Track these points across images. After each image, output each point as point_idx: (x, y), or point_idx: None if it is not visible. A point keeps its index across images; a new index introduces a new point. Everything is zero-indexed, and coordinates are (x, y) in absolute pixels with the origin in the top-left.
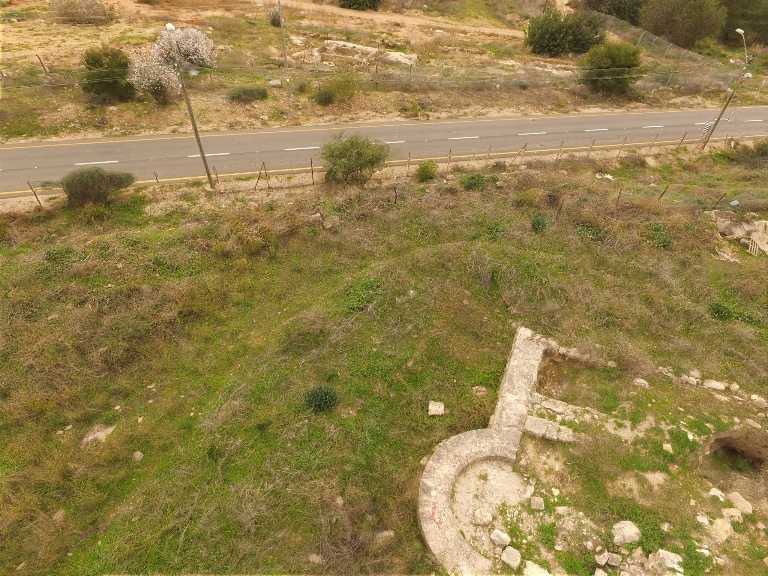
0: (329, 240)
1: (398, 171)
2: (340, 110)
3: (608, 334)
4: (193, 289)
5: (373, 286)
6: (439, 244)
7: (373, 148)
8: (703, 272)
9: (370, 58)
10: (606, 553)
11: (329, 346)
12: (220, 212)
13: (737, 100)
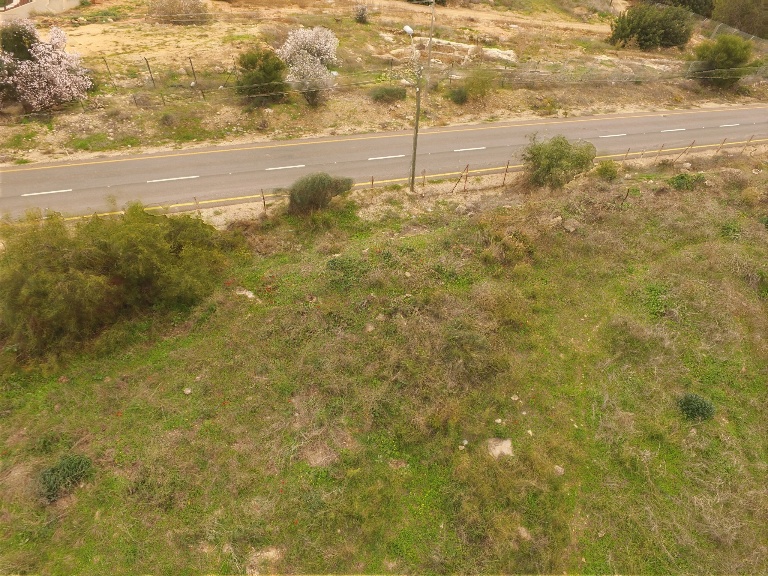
0: (587, 244)
1: None
2: (476, 109)
3: None
4: (501, 297)
5: (660, 290)
6: (686, 246)
7: (580, 149)
8: None
9: (472, 55)
10: None
11: (665, 353)
12: (432, 216)
13: None
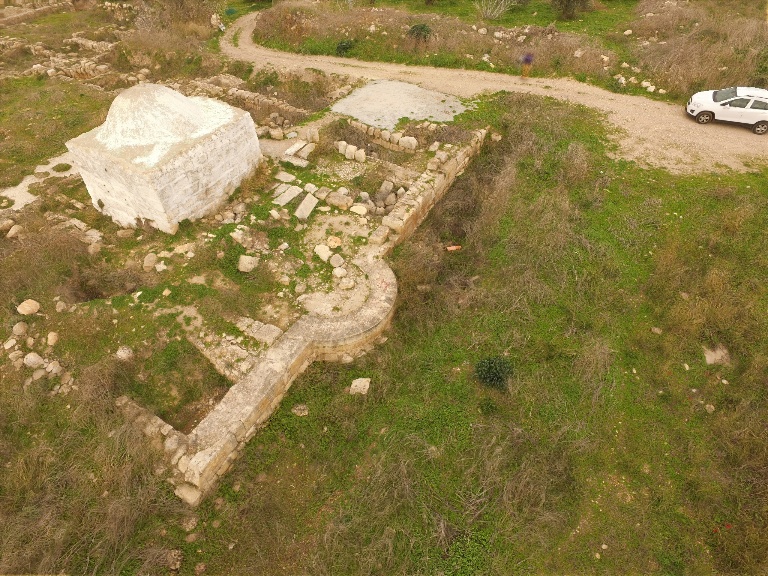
0: None
1: None
2: None
3: None
4: None
5: None
6: None
7: None
8: None
9: None
10: None
11: None
12: None
13: None
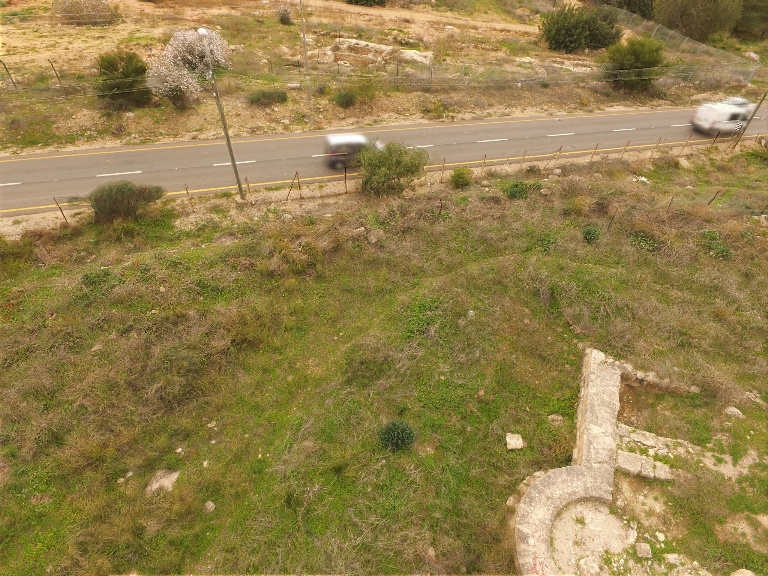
0: (378, 256)
1: (431, 177)
2: (362, 112)
3: (685, 356)
4: (244, 315)
5: (431, 307)
6: (491, 258)
7: (412, 156)
8: (767, 284)
9: (385, 57)
10: None
11: (396, 375)
12: (254, 225)
13: None
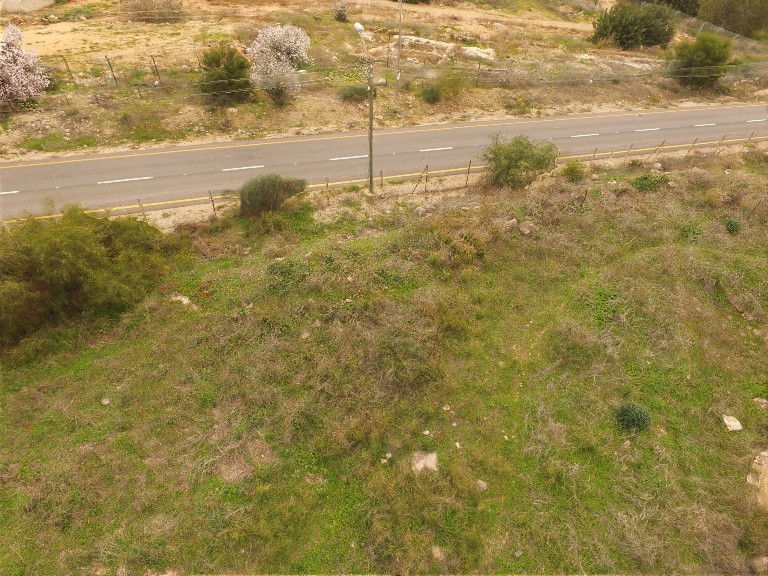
0: (540, 247)
1: None
2: (448, 108)
3: None
4: (442, 303)
5: (610, 295)
6: (643, 248)
7: (542, 149)
8: None
9: (450, 53)
10: None
11: (607, 360)
12: (390, 218)
13: None
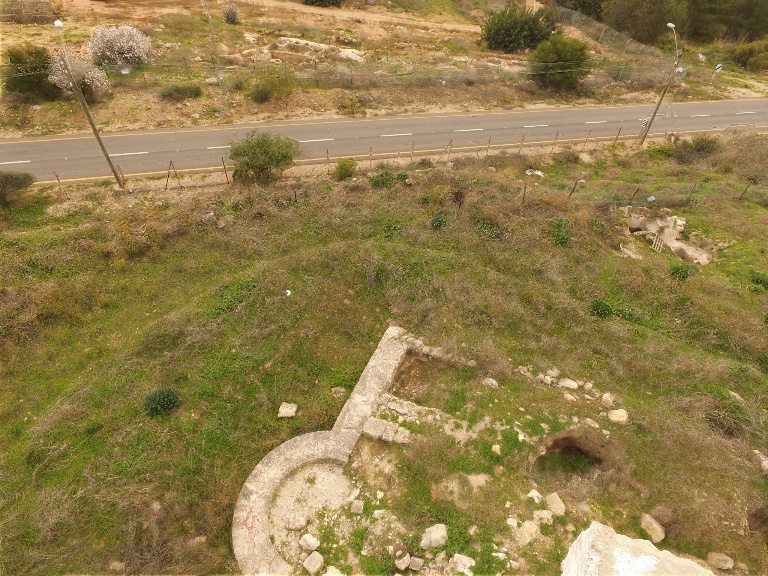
0: (216, 240)
1: (319, 169)
2: (276, 108)
3: (477, 333)
4: (57, 291)
5: (249, 286)
6: (332, 243)
7: (281, 146)
8: (595, 269)
9: (320, 55)
10: (406, 557)
11: (185, 348)
12: None
13: (672, 95)
